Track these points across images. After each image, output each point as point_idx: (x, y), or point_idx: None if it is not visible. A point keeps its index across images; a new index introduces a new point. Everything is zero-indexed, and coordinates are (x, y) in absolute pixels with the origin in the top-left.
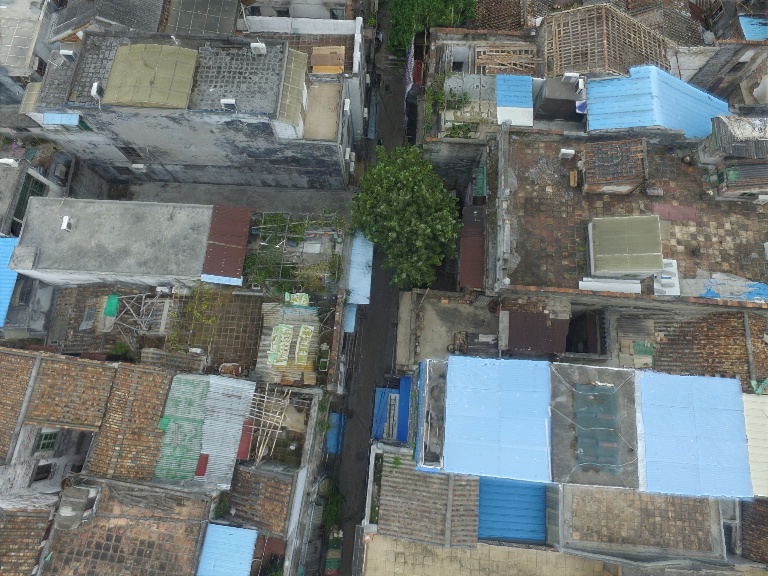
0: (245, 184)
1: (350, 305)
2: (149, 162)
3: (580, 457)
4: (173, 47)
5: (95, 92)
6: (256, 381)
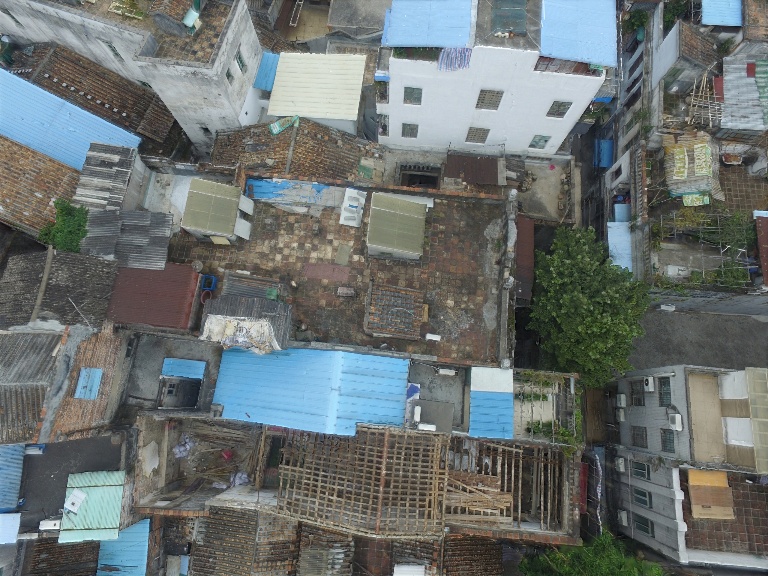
0: None
1: None
2: None
3: None
4: None
5: None
6: (715, 138)
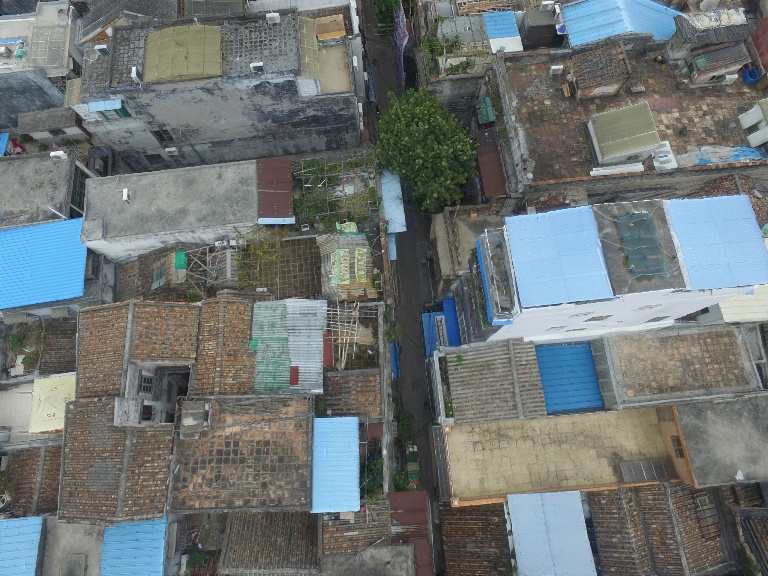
0: (267, 156)
1: (389, 236)
2: (180, 144)
3: (633, 270)
4: (199, 26)
5: (135, 75)
6: None
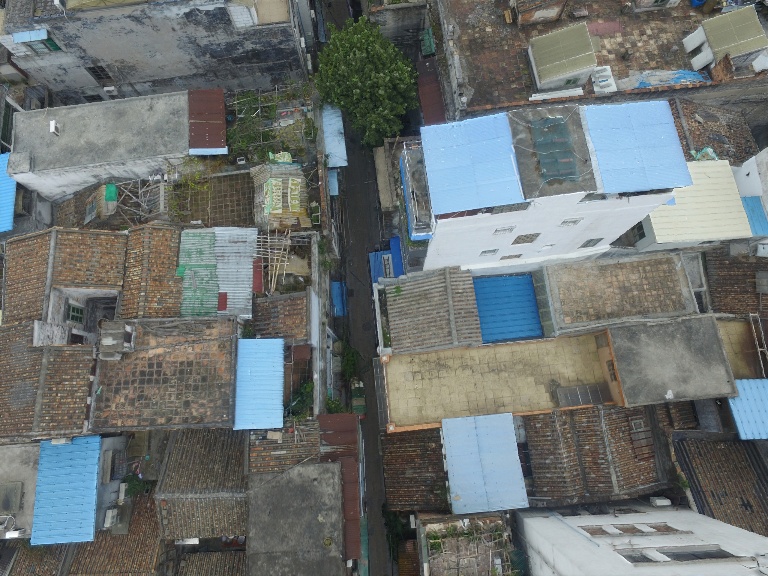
0: None
1: (330, 171)
2: (119, 83)
3: (544, 173)
4: None
5: (58, 1)
6: None
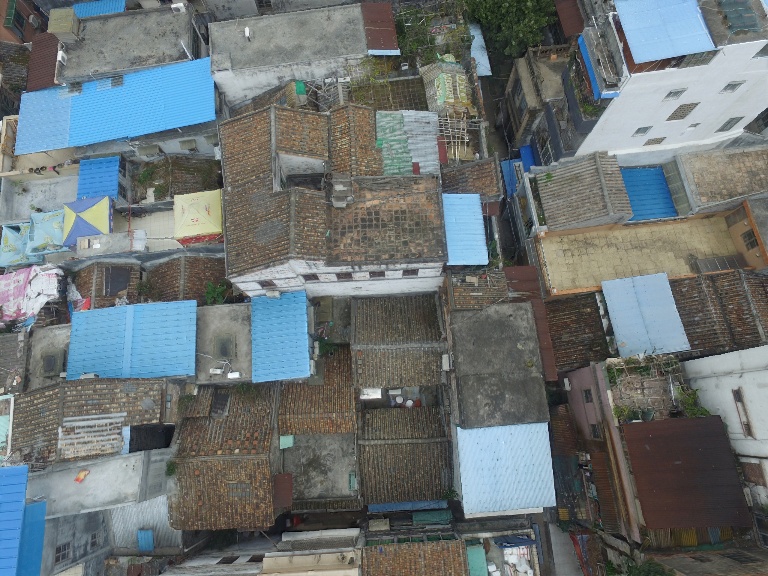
0: None
1: None
2: (275, 12)
3: (732, 25)
4: None
5: None
6: None
